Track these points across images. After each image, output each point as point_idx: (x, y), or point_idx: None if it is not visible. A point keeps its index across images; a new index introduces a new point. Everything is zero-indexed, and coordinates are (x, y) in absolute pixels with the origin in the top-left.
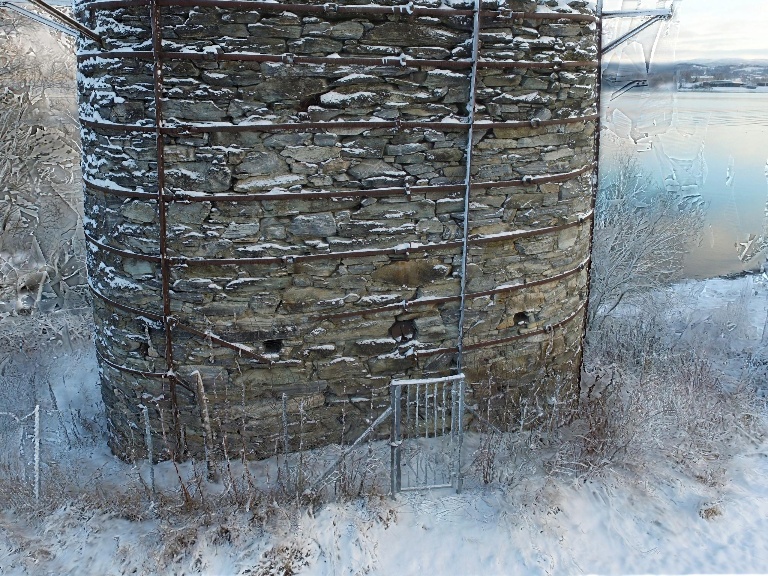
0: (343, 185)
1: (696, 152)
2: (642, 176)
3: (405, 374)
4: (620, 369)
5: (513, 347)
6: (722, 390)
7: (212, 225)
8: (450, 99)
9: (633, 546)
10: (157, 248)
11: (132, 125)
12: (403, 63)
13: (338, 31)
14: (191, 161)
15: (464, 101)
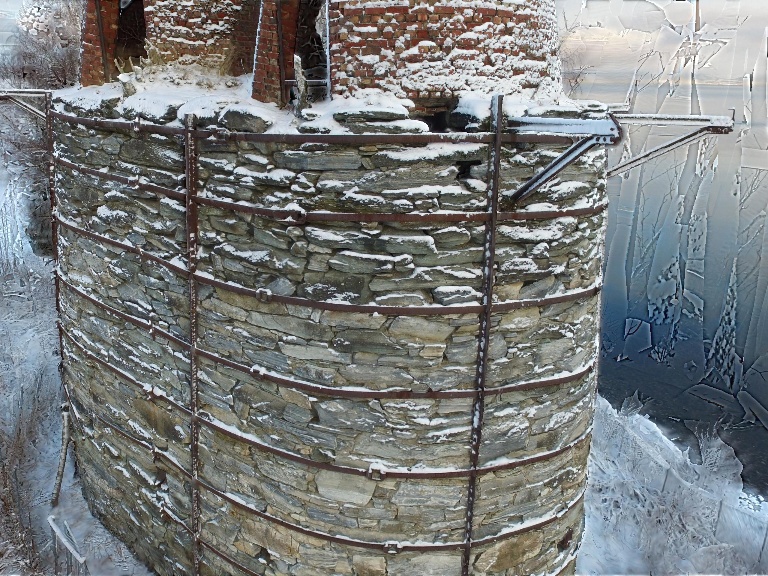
0: (114, 301)
1: None
2: None
3: (163, 524)
4: None
5: None
6: None
7: None
8: (179, 236)
9: None
10: None
11: None
12: (136, 186)
13: None
14: None
15: None
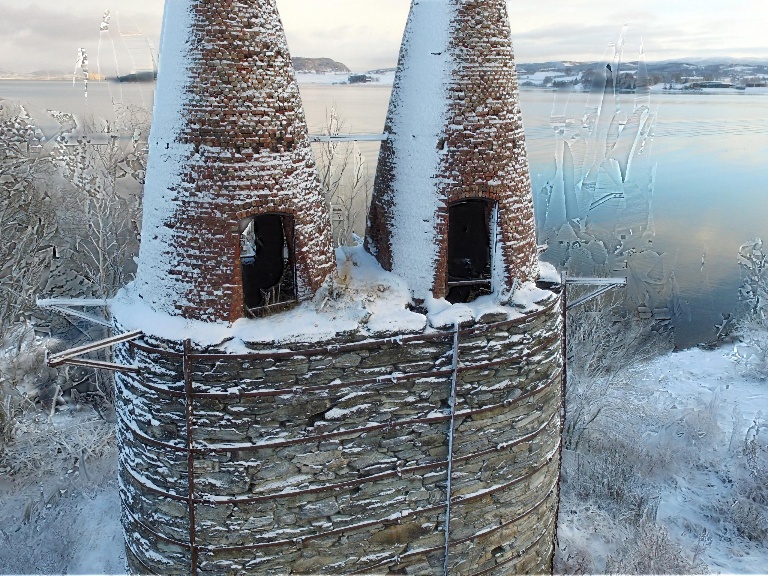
0: (344, 476)
1: (667, 277)
2: (618, 290)
3: None
4: (594, 506)
5: (491, 574)
6: (688, 521)
7: (234, 520)
8: (434, 398)
9: None
10: (187, 536)
11: (166, 443)
12: (394, 381)
13: (339, 363)
14: (216, 472)
15: (446, 397)
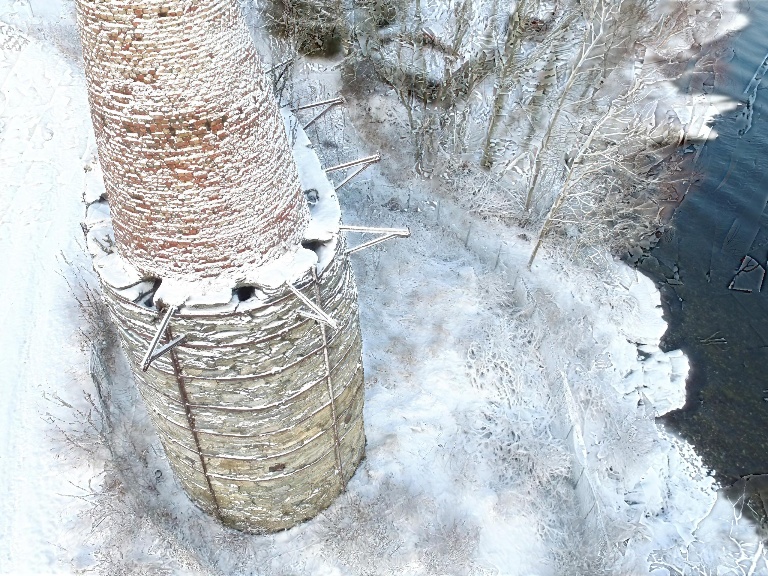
0: None
1: None
2: None
3: None
4: None
5: None
6: None
7: None
8: None
9: (67, 509)
10: None
11: None
12: None
13: None
14: None
15: None
